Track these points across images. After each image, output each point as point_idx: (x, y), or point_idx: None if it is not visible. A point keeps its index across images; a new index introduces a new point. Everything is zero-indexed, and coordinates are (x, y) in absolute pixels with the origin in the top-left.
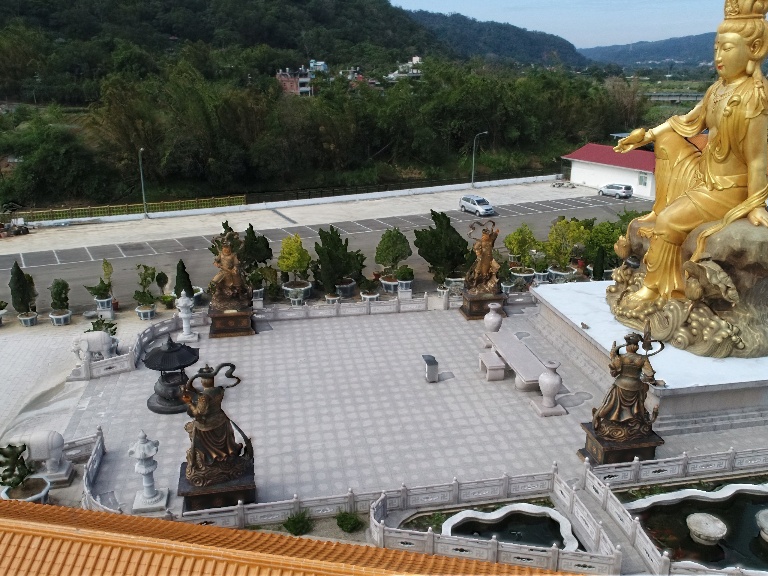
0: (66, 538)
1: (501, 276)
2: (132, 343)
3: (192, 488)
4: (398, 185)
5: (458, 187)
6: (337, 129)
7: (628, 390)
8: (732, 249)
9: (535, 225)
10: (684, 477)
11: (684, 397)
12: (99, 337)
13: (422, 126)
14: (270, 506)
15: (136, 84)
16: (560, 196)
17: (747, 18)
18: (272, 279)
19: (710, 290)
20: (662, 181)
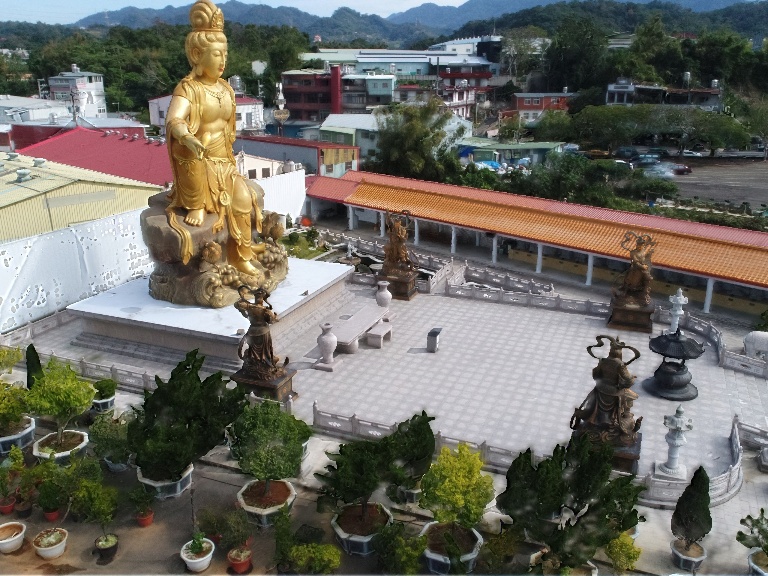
0: None
1: None
2: (763, 507)
3: None
4: None
5: None
6: None
7: None
8: None
9: None
10: None
11: None
12: None
13: None
14: None
15: None
16: None
17: None
18: None
19: None
20: None
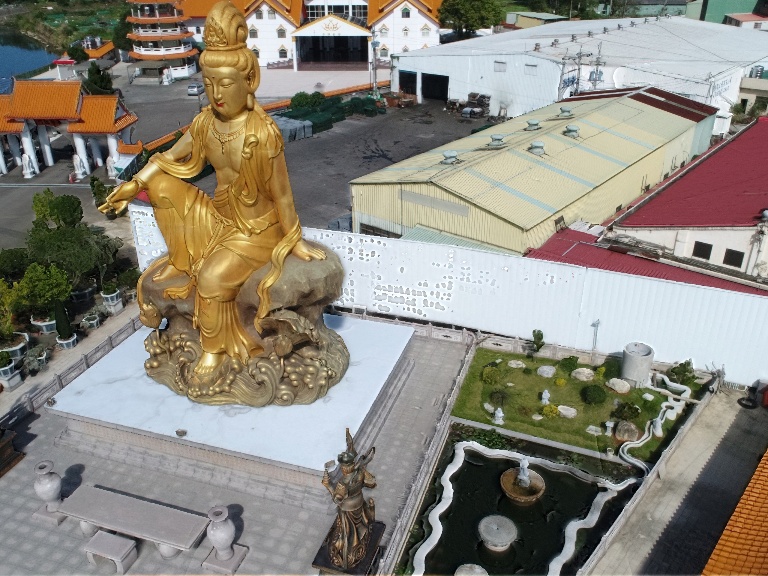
0: None
1: None
2: None
3: None
4: None
5: None
6: None
7: None
8: (303, 293)
9: None
10: (402, 539)
11: None
12: None
13: None
14: None
15: None
16: None
17: (236, 49)
18: None
19: (295, 338)
20: (174, 233)
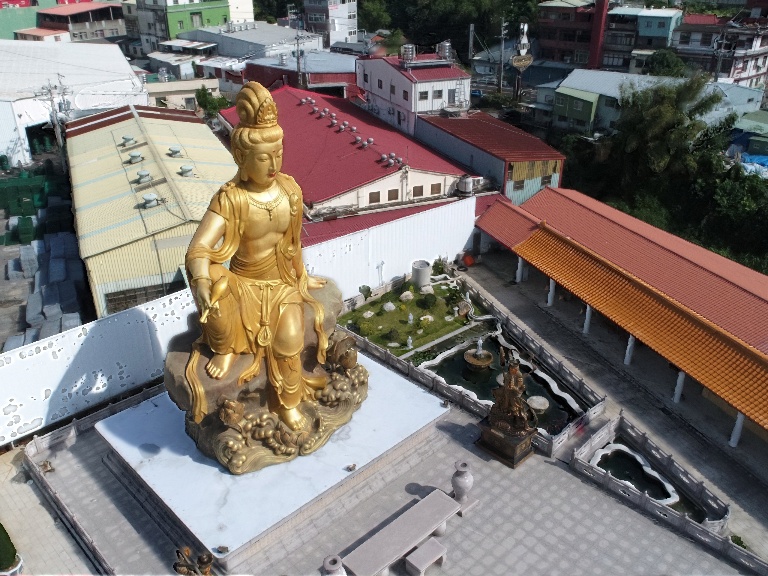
0: None
1: None
2: None
3: None
4: None
5: None
6: None
7: None
8: None
9: None
10: None
11: None
12: None
13: None
14: None
15: None
16: None
17: None
18: None
19: None
20: None
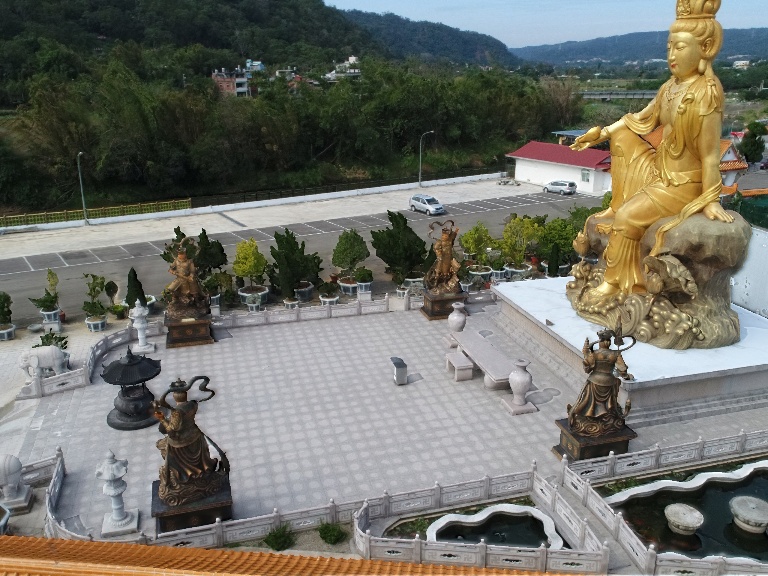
0: (44, 573)
1: (459, 275)
2: (84, 357)
3: (166, 508)
4: (346, 186)
5: (406, 186)
6: (279, 130)
7: (602, 386)
8: (690, 243)
9: (485, 223)
10: (657, 468)
11: (651, 389)
12: (50, 352)
13: (365, 126)
14: (249, 522)
15: (67, 85)
16: (507, 194)
17: (698, 18)
18: (227, 285)
19: (670, 284)
20: (618, 178)
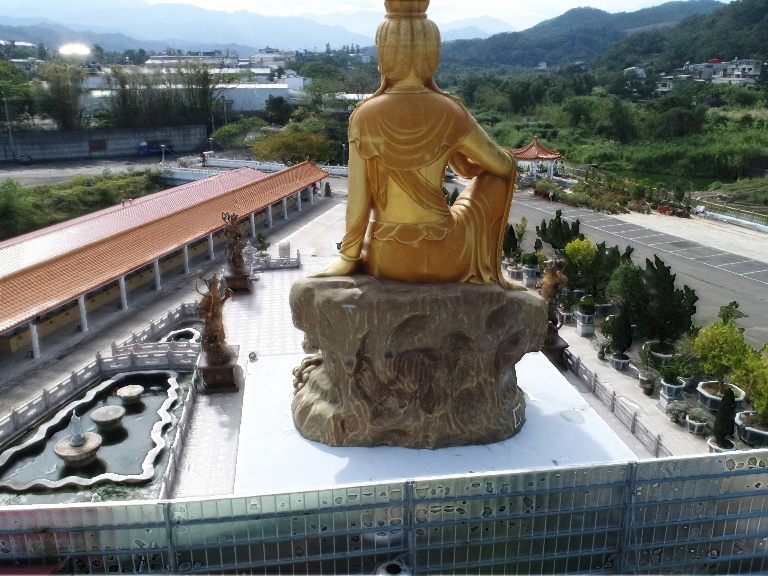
0: None
1: None
2: None
3: None
4: None
5: None
6: None
7: None
8: None
9: None
10: None
11: None
12: None
13: None
14: None
15: None
16: None
17: None
18: None
19: None
20: None
